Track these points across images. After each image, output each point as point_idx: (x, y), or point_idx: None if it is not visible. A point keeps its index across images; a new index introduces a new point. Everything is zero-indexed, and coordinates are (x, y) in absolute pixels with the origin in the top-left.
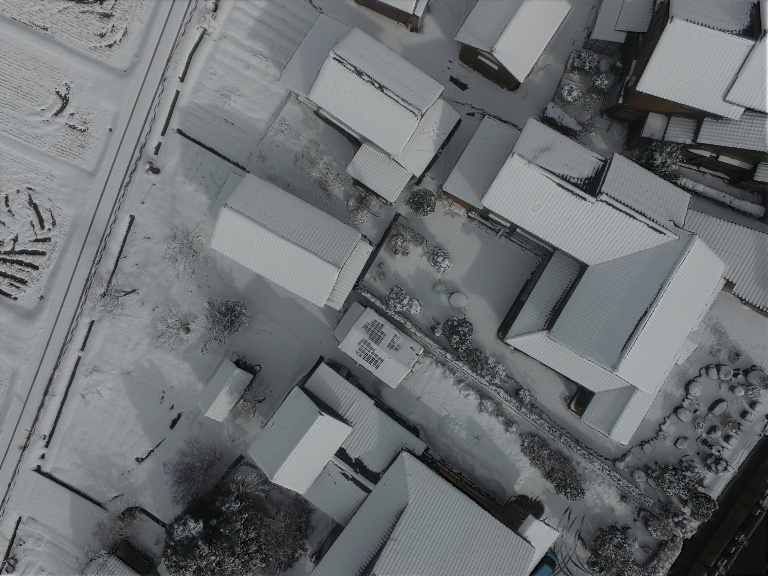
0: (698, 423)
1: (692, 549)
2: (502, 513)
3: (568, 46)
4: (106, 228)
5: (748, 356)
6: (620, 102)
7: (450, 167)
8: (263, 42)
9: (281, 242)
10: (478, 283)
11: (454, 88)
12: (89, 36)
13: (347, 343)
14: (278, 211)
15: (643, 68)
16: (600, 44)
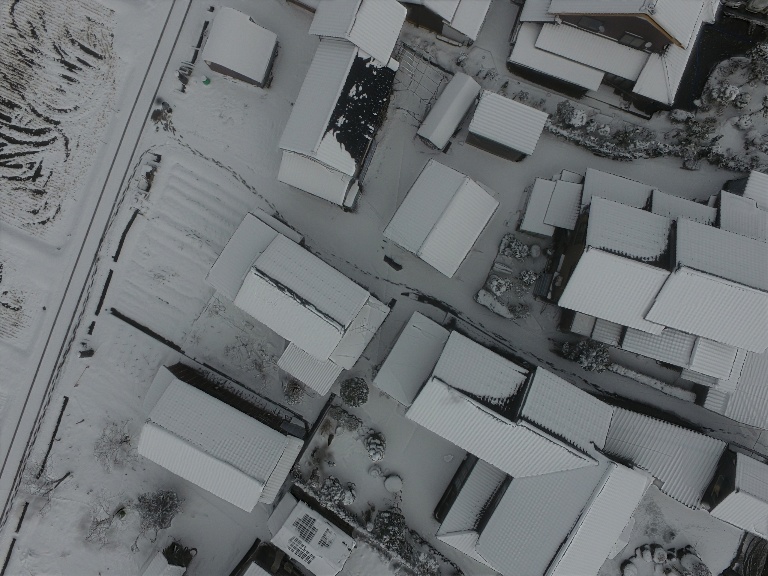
0: None
1: None
2: None
3: (501, 227)
4: (40, 409)
5: (683, 536)
6: (549, 298)
7: (385, 348)
8: (197, 222)
9: (205, 457)
10: (414, 464)
11: (388, 269)
12: (22, 213)
13: (279, 539)
14: (203, 421)
15: (568, 272)
16: (531, 232)
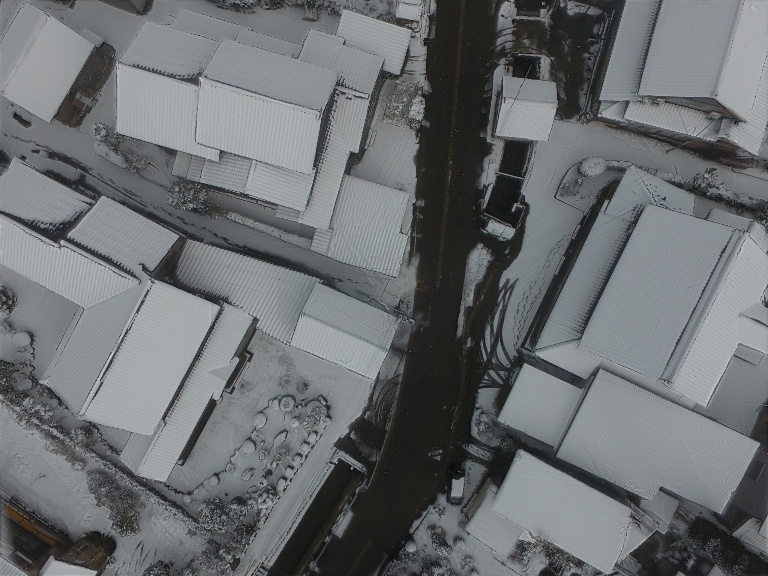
0: (259, 454)
1: (280, 575)
2: (62, 551)
3: None
4: None
5: (315, 386)
6: None
7: None
8: None
9: None
10: (47, 321)
11: (17, 126)
12: None
13: None
14: None
15: None
16: None
